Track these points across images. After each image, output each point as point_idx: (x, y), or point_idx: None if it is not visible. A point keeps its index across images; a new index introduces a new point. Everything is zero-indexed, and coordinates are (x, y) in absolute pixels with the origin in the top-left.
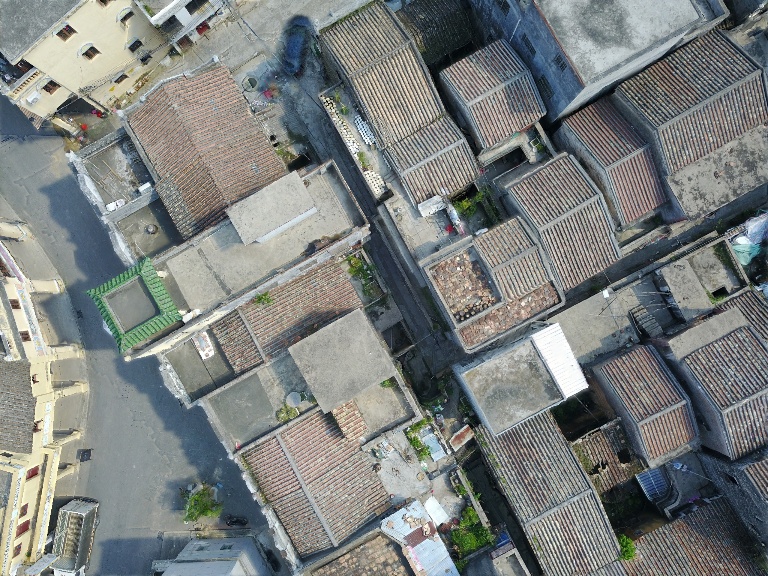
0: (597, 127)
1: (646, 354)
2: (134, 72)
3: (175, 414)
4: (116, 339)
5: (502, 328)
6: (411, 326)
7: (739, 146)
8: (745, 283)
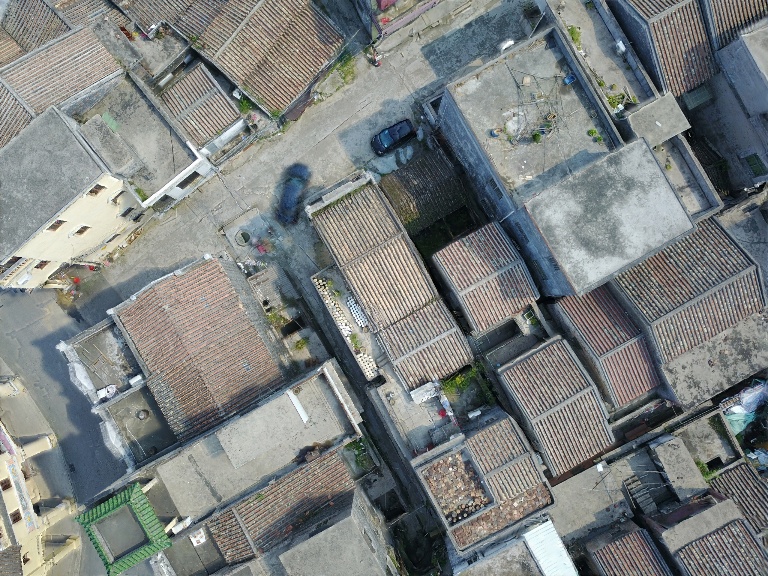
0: (591, 310)
1: (640, 540)
2: (126, 229)
3: None
4: (105, 565)
5: (494, 529)
6: (405, 483)
7: (733, 334)
8: (740, 455)
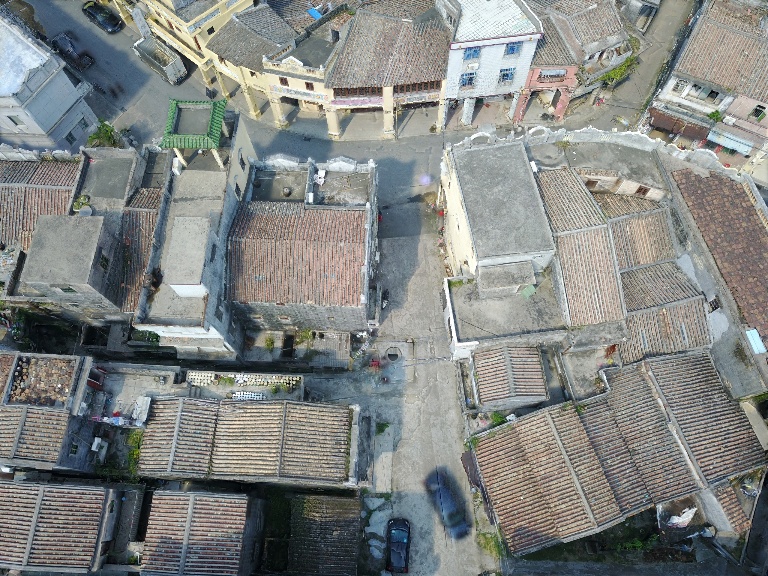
0: None
1: None
2: None
3: None
4: None
5: None
6: None
7: None
8: None
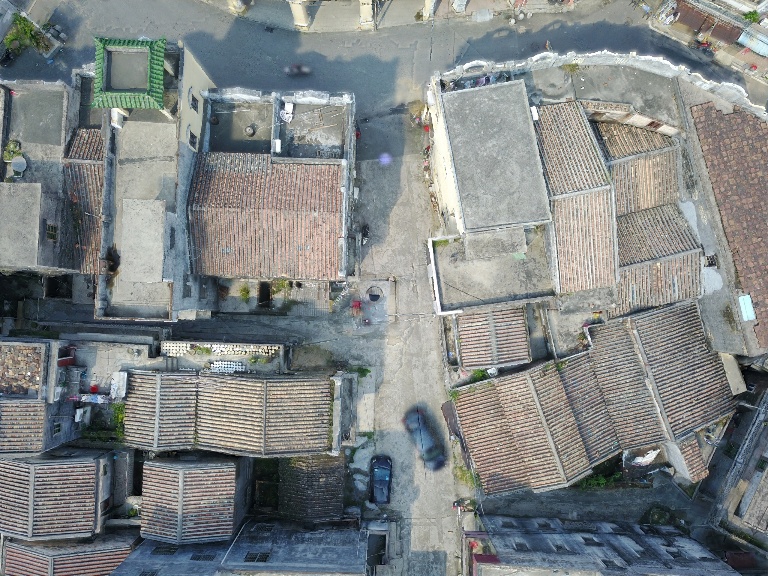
0: (103, 573)
1: None
2: None
3: None
4: (109, 40)
5: None
6: (80, 306)
7: None
8: None
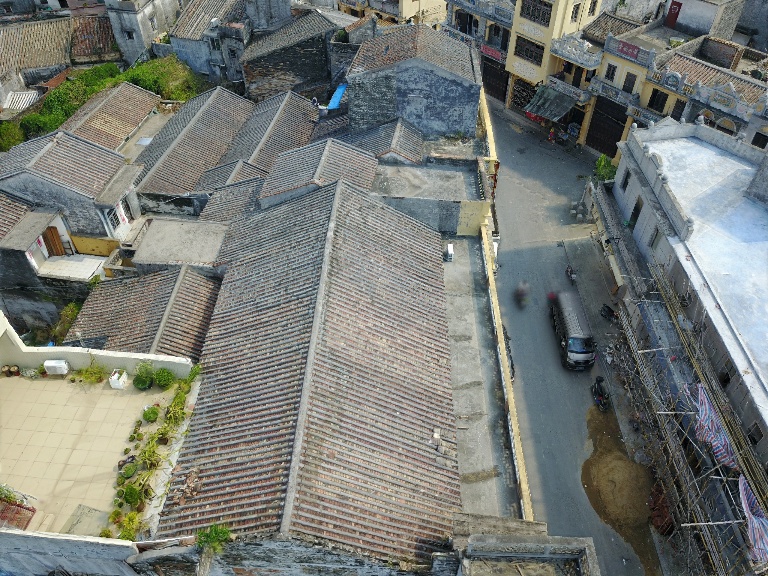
0: None
1: None
2: None
3: (534, 169)
4: None
5: None
6: None
7: None
8: None
